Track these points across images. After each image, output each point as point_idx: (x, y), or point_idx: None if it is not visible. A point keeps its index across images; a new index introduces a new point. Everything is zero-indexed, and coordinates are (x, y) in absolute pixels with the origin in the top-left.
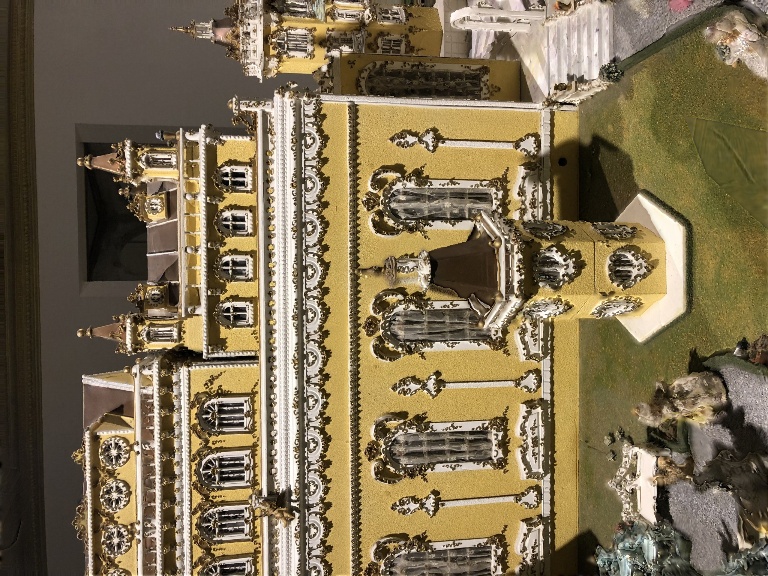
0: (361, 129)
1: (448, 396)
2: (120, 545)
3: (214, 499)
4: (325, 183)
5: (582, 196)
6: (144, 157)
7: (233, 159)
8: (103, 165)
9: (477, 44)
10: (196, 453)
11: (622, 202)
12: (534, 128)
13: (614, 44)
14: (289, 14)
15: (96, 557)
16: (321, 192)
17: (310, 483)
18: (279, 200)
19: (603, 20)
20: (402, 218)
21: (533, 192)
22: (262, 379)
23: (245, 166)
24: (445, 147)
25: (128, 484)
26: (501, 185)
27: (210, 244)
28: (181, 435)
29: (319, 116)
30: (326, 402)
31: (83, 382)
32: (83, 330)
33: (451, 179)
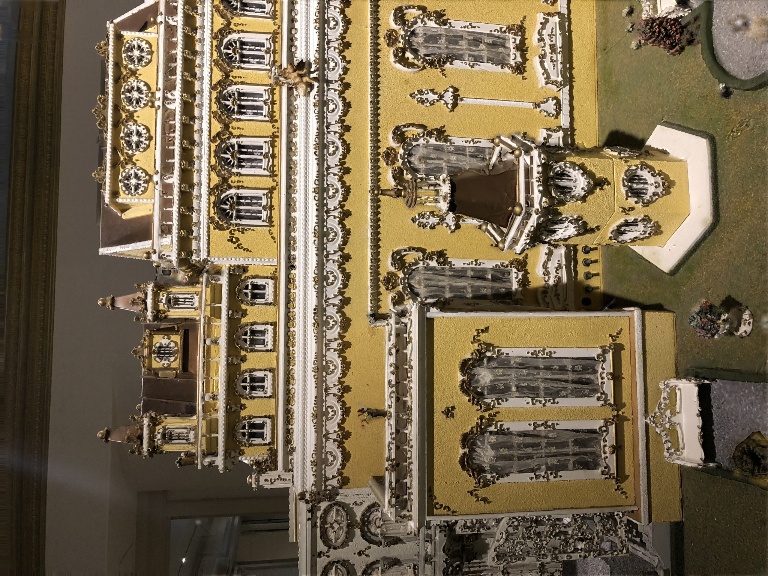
0: None
1: None
2: (138, 145)
3: (234, 78)
4: None
5: None
6: None
7: None
8: None
9: None
10: (218, 31)
11: None
12: None
13: None
14: None
15: (114, 151)
16: None
17: (329, 60)
18: None
19: None
20: None
21: None
22: None
23: None
24: None
25: (149, 85)
26: None
27: None
28: (204, 16)
29: None
30: None
31: (108, 25)
32: None
33: None
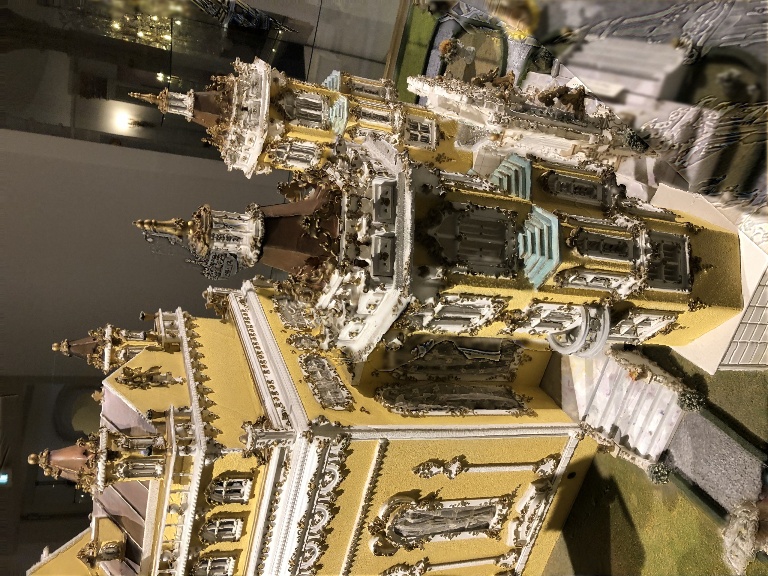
0: (386, 461)
1: None
2: None
3: None
4: (334, 514)
5: (577, 508)
6: (123, 468)
7: (232, 470)
8: (66, 467)
9: None
10: None
11: (619, 575)
12: (558, 449)
13: (673, 438)
14: (299, 123)
15: None
16: (328, 523)
17: None
18: (281, 534)
19: (672, 407)
20: (403, 535)
21: (536, 509)
22: None
23: (245, 479)
24: (467, 472)
25: None
26: (508, 503)
27: (191, 558)
28: None
29: (345, 453)
30: None
31: None
32: None
33: (463, 499)
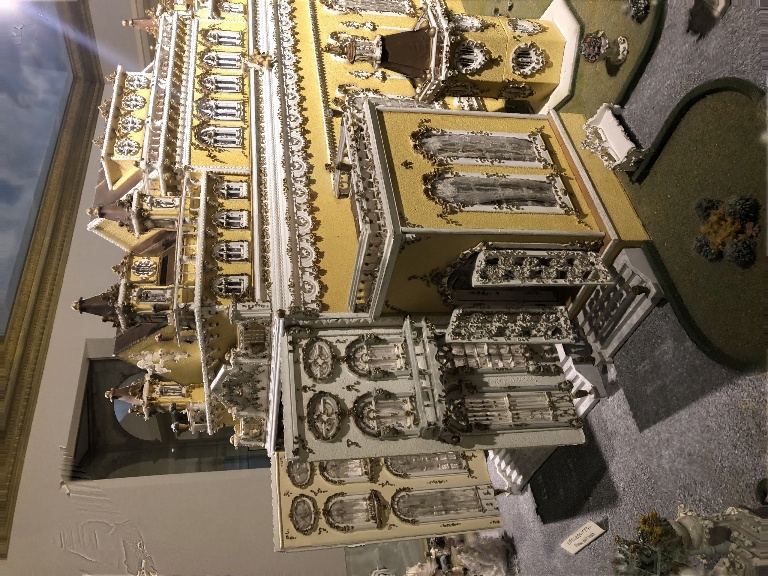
0: None
1: (382, 32)
2: None
3: None
4: None
5: None
6: None
7: None
8: None
9: None
10: (200, 52)
11: None
12: None
13: None
14: None
15: (112, 131)
16: None
17: (285, 56)
18: None
19: None
20: None
21: None
22: (249, 16)
23: None
24: None
25: (144, 98)
26: None
27: None
28: (190, 47)
29: None
30: (295, 26)
31: None
32: None
33: None
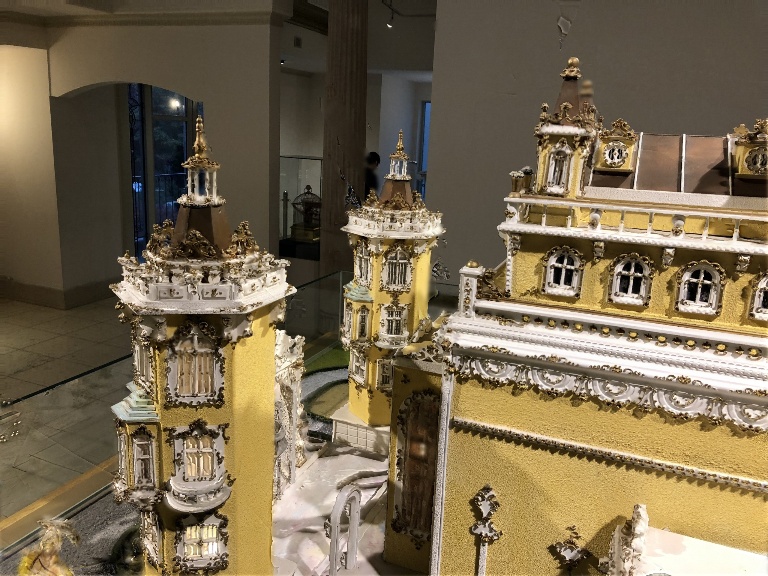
0: None
1: None
2: None
3: None
4: None
5: None
6: None
7: None
8: None
9: (300, 561)
10: None
11: None
12: None
13: None
14: None
15: None
16: None
17: None
18: None
19: None
20: None
21: None
22: None
23: None
24: None
25: None
26: None
27: None
28: None
29: None
30: None
31: None
32: None
33: None
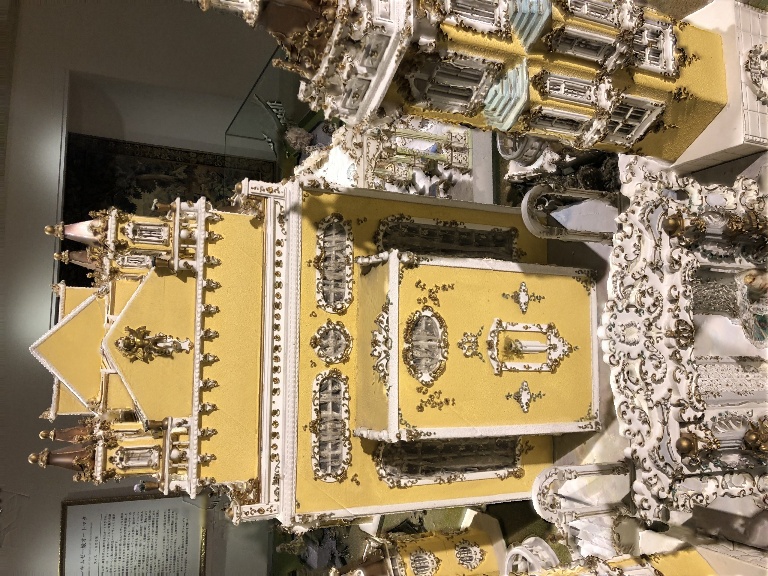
0: None
1: None
2: None
3: None
4: None
5: None
6: None
7: None
8: None
9: None
10: None
11: None
12: None
13: None
14: (428, 107)
15: None
16: None
17: None
18: None
19: None
20: None
21: None
22: None
23: None
24: None
25: None
26: None
27: None
28: None
29: None
30: None
31: None
32: (46, 435)
33: None
